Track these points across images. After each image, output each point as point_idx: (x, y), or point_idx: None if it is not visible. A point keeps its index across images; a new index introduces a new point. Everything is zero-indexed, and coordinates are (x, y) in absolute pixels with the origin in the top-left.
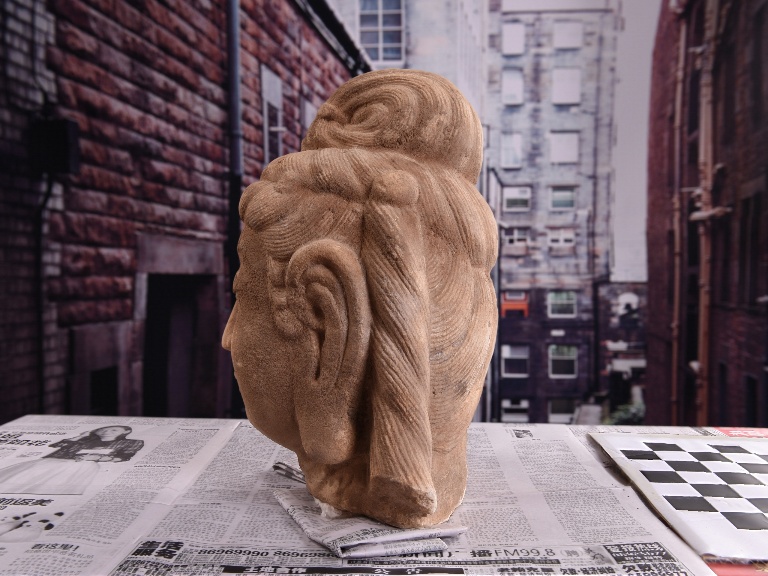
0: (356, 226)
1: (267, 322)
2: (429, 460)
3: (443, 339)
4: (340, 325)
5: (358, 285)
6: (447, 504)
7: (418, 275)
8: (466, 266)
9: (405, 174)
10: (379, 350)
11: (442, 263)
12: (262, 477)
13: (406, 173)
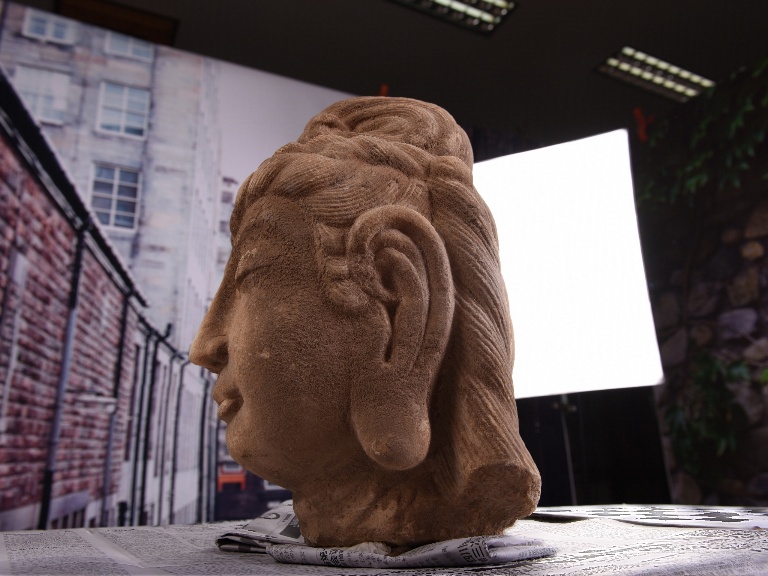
0: (425, 198)
1: (314, 297)
2: None
3: None
4: (422, 294)
5: (443, 250)
6: None
7: None
8: None
9: None
10: (471, 320)
11: None
12: (211, 552)
13: None
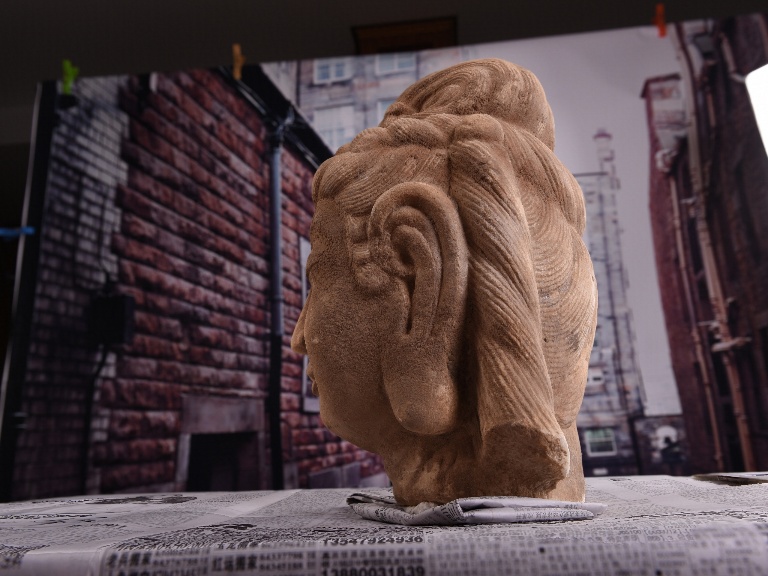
0: (442, 167)
1: (347, 284)
2: (552, 410)
3: (548, 279)
4: (433, 263)
5: (451, 216)
6: (573, 489)
7: (517, 200)
8: (560, 213)
9: (489, 115)
10: (481, 280)
11: (536, 204)
12: (336, 509)
13: (489, 115)
